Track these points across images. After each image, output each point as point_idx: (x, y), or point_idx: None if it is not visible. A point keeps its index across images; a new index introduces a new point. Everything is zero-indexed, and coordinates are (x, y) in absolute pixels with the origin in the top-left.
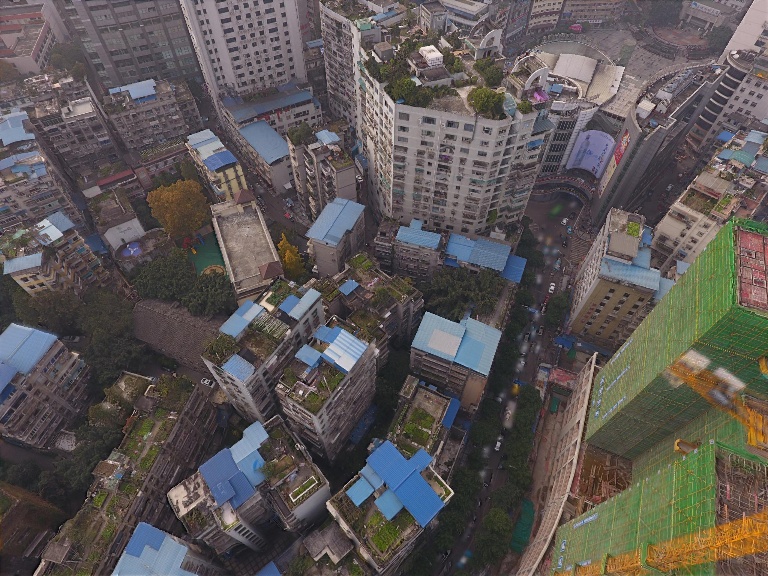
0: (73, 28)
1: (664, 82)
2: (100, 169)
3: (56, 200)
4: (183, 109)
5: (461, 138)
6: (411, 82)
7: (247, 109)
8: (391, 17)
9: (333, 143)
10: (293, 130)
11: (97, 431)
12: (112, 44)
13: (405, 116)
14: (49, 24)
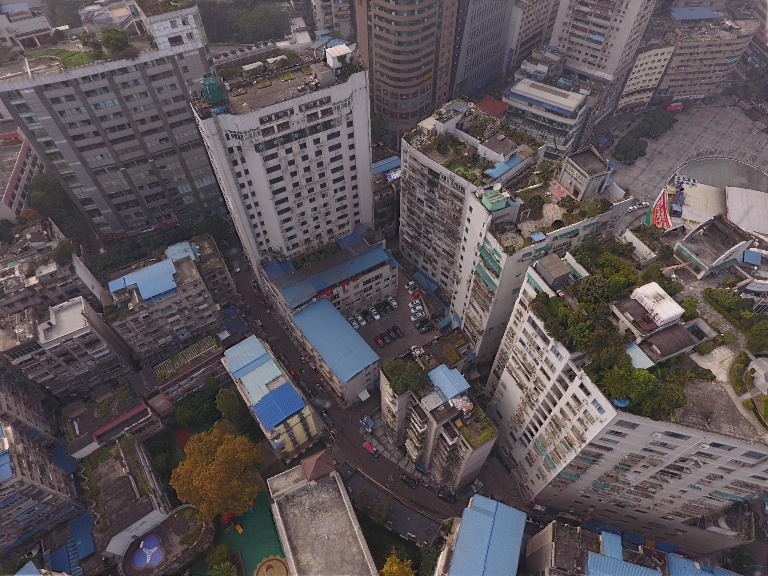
0: (57, 174)
1: None
2: (97, 403)
3: (29, 499)
4: (211, 280)
5: (728, 459)
6: None
7: (301, 284)
8: (513, 166)
9: (459, 393)
10: (392, 366)
11: None
12: (111, 186)
13: (628, 423)
14: (29, 144)
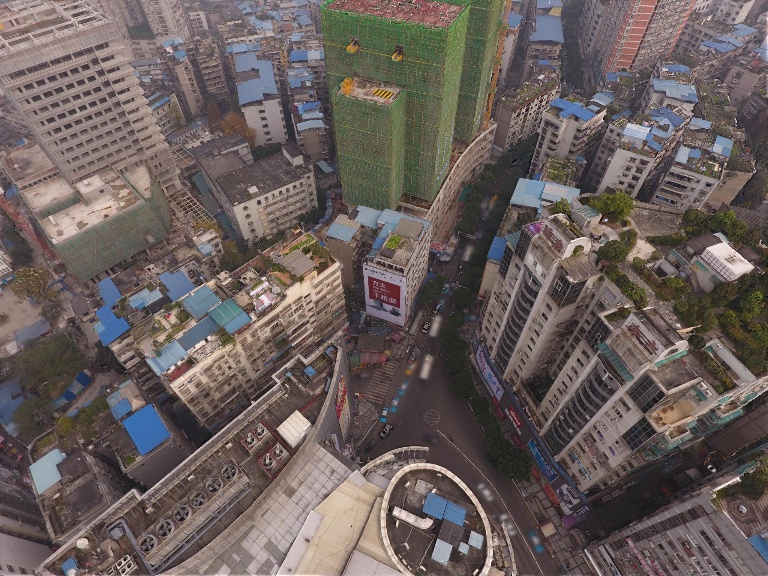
0: None
1: (194, 551)
2: None
3: None
4: None
5: None
6: (726, 215)
7: None
8: None
9: None
10: None
11: (764, 147)
12: None
13: None
14: None
